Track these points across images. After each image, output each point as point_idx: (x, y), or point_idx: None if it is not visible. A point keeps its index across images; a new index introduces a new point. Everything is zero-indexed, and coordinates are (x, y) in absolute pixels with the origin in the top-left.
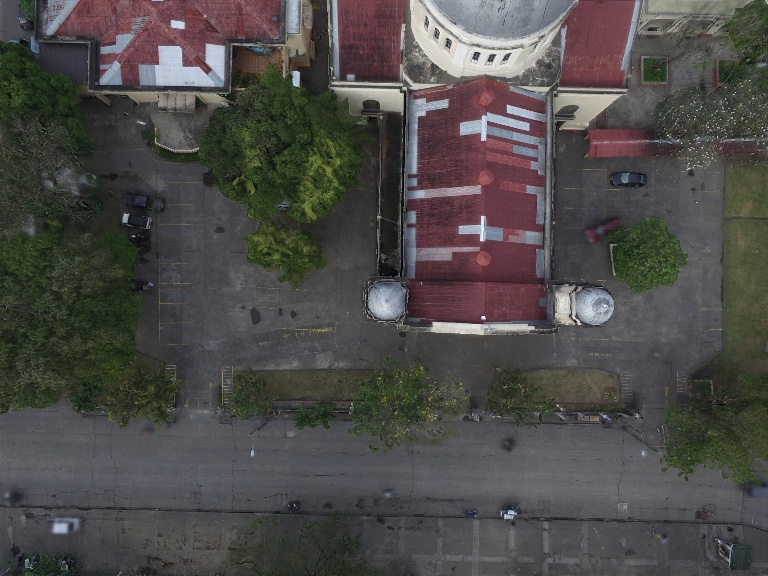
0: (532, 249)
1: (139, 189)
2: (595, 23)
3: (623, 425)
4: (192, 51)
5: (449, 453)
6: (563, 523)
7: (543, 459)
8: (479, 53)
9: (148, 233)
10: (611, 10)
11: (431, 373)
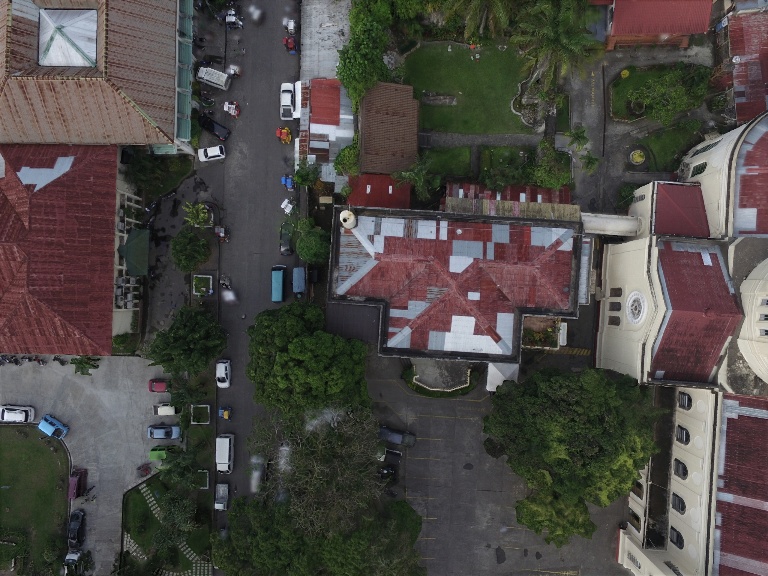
0: None
1: (389, 420)
2: None
3: None
4: (485, 321)
5: None
6: None
7: None
8: None
9: (397, 466)
10: None
11: None
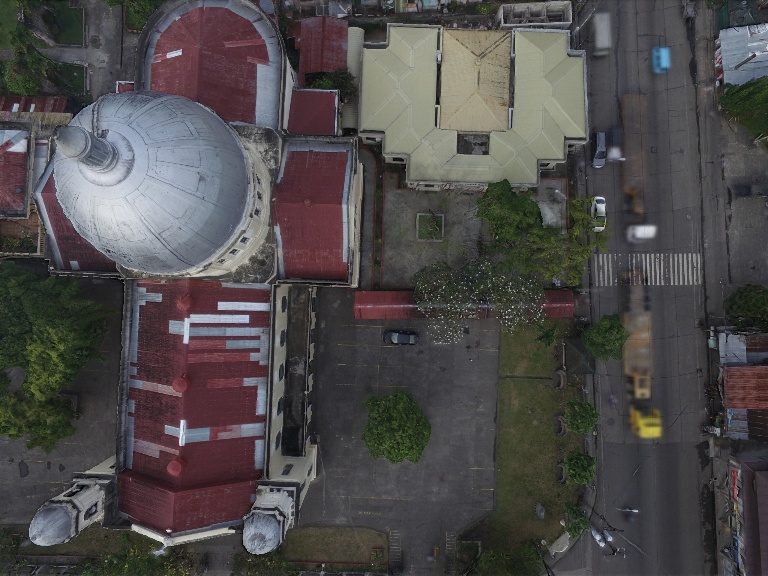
0: (250, 442)
1: None
2: (306, 222)
3: None
4: None
5: None
6: None
7: None
8: None
9: None
10: (320, 211)
11: None
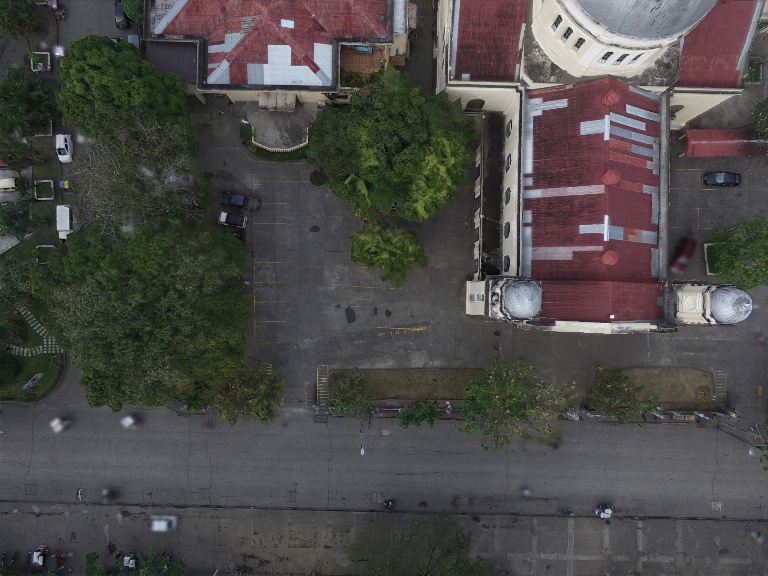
0: (648, 248)
1: (234, 188)
2: (715, 23)
3: (717, 424)
4: (301, 50)
5: (544, 452)
6: (657, 522)
7: (637, 458)
8: (612, 53)
9: (243, 232)
10: (733, 10)
11: None
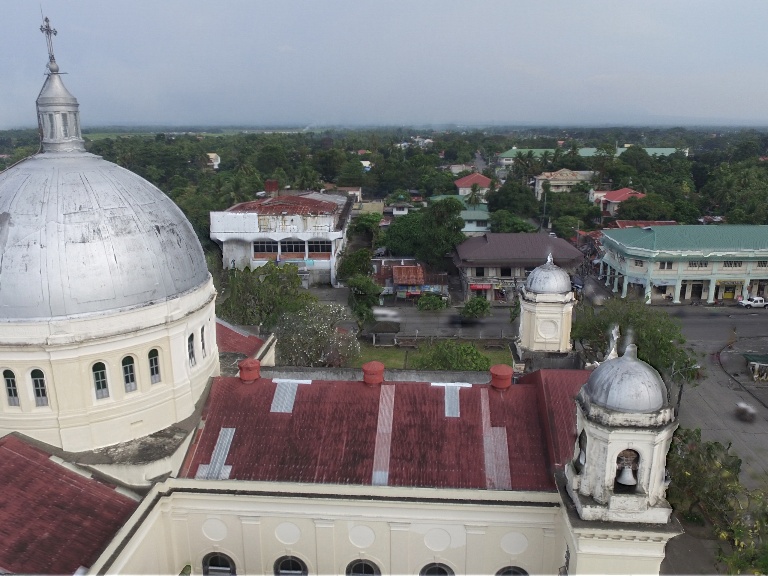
0: None
1: None
2: None
3: None
4: None
5: None
6: None
7: None
8: (192, 337)
9: None
10: None
11: None
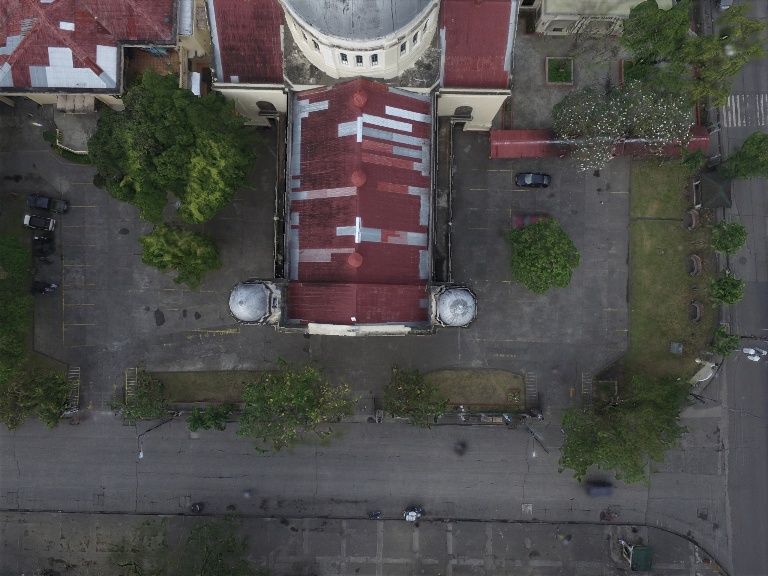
0: (415, 250)
1: (43, 191)
2: (473, 24)
3: None
4: (82, 52)
5: (353, 454)
6: (467, 524)
7: (447, 460)
8: (345, 54)
9: (52, 235)
10: (488, 11)
11: (335, 374)
